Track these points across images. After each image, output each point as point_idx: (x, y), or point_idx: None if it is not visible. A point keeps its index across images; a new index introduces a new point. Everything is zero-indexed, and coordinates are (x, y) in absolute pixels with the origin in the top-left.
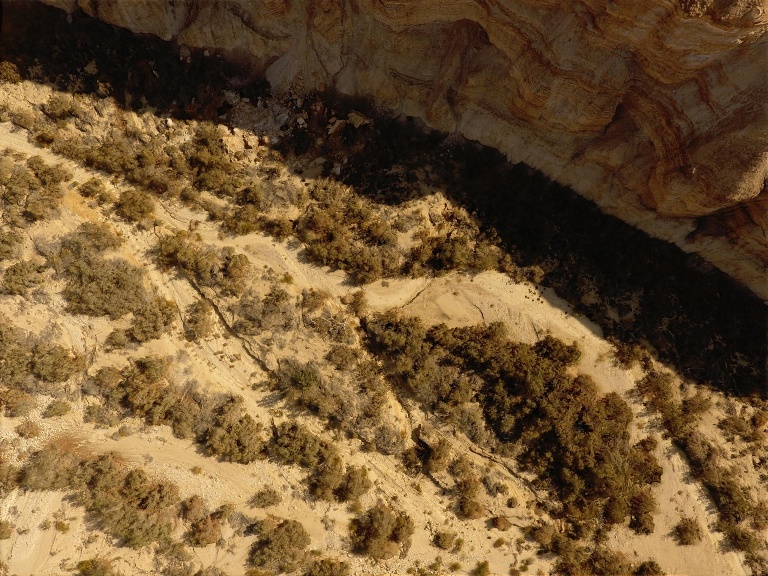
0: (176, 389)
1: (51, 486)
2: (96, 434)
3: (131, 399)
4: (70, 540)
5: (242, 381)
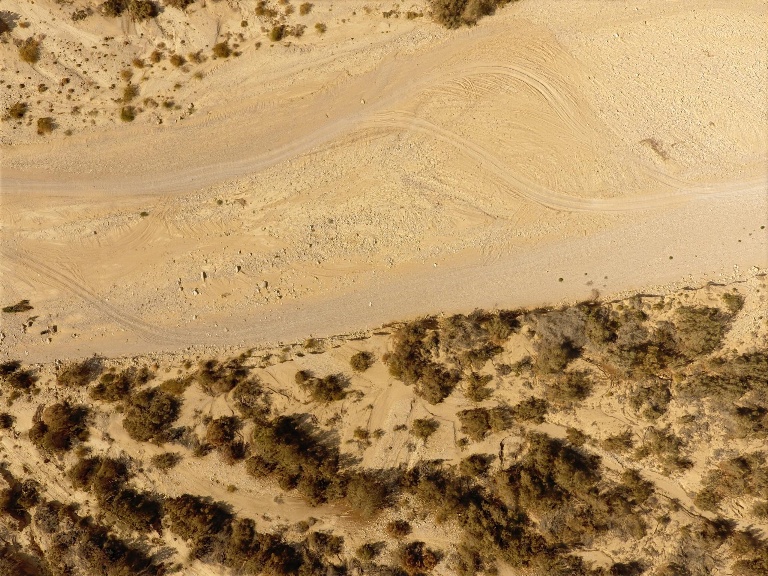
0: (250, 572)
1: (358, 488)
2: (331, 524)
3: (280, 575)
4: (353, 421)
5: (192, 573)
